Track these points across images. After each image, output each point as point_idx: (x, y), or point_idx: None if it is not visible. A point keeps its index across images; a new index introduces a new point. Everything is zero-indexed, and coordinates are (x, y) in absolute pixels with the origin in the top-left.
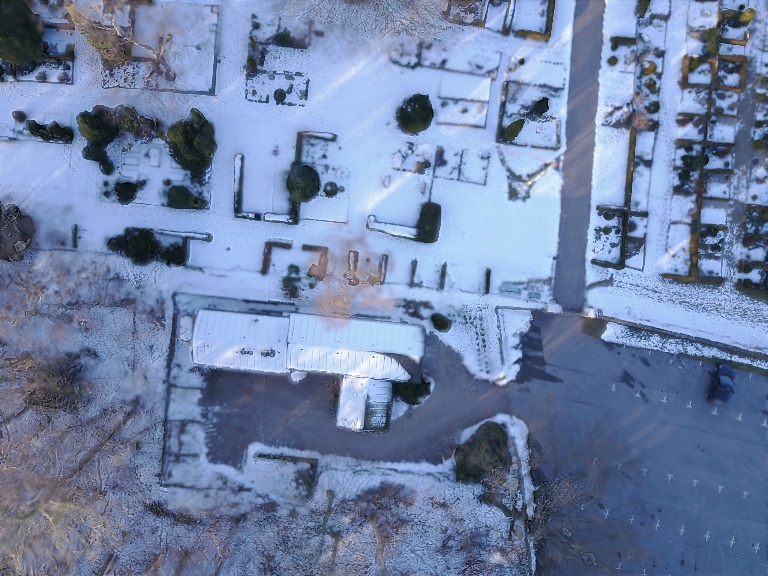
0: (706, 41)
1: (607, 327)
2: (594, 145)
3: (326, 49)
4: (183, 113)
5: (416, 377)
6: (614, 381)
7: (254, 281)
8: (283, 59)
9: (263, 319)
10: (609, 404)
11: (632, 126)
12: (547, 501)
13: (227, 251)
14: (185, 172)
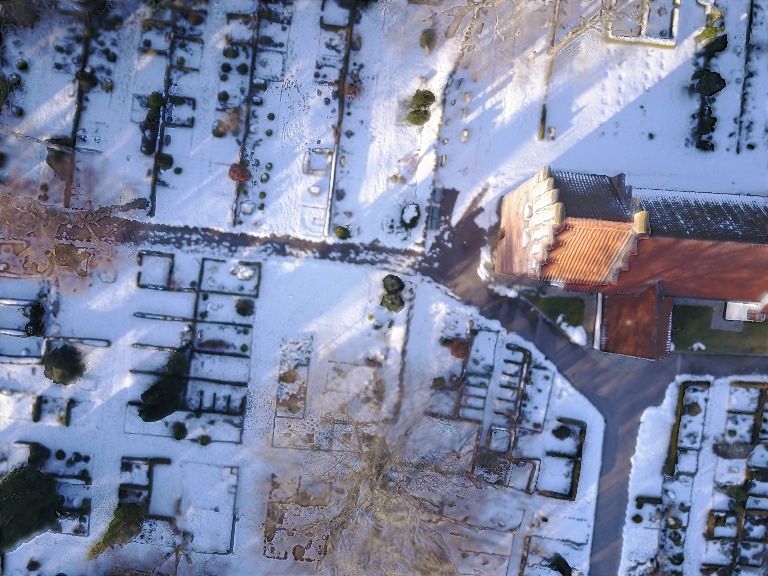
0: (733, 497)
1: None
2: None
3: None
4: (200, 569)
5: None
6: None
7: None
8: (303, 516)
9: None
10: None
11: None
12: None
13: None
14: None
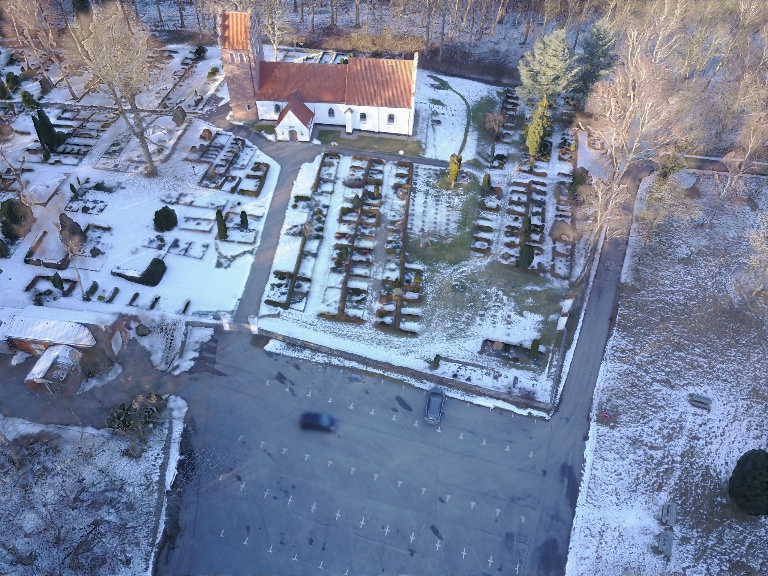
0: None
1: (269, 341)
2: (278, 243)
3: (124, 194)
4: None
5: (100, 343)
6: (269, 378)
7: (16, 295)
8: (96, 196)
9: (7, 308)
10: (262, 394)
11: (303, 234)
12: (189, 469)
13: (8, 280)
14: (6, 240)
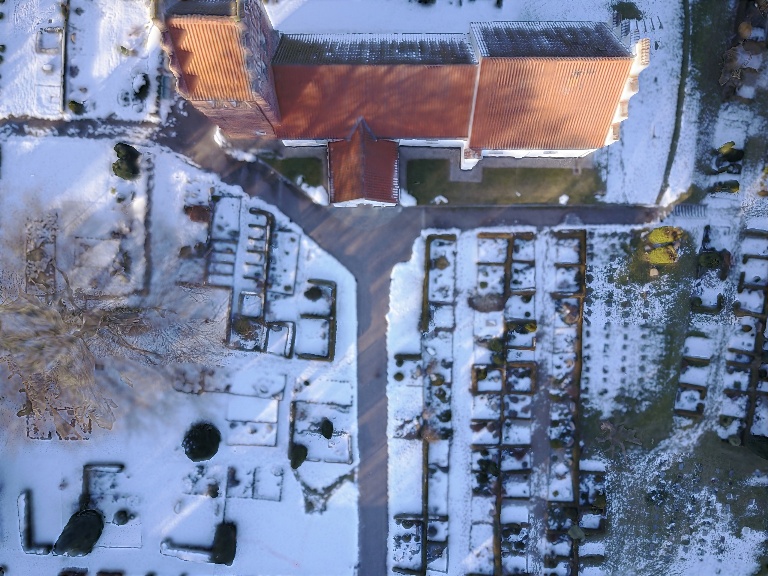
0: (493, 350)
1: None
2: (387, 457)
3: (108, 381)
4: None
5: None
6: None
7: None
8: None
9: None
10: None
11: (423, 438)
12: None
13: None
14: None
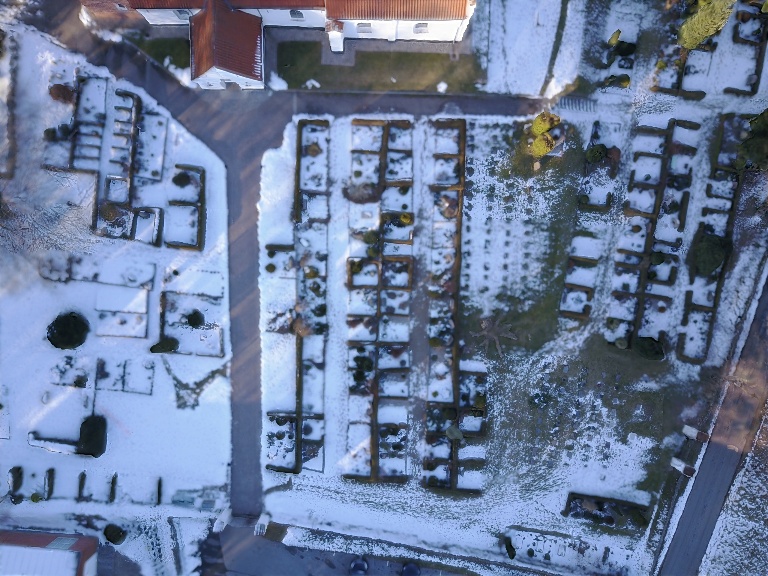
0: (369, 243)
1: (287, 531)
2: (260, 351)
3: None
4: None
5: None
6: None
7: None
8: None
9: None
10: None
11: (296, 332)
12: None
13: None
14: None
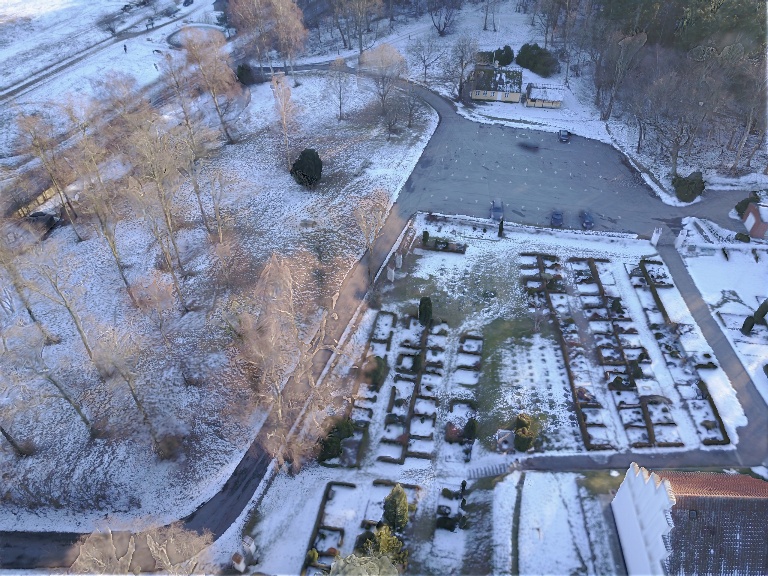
0: None
1: None
2: None
3: None
4: None
5: None
6: None
7: None
8: None
9: None
10: None
11: None
12: None
13: None
14: None
